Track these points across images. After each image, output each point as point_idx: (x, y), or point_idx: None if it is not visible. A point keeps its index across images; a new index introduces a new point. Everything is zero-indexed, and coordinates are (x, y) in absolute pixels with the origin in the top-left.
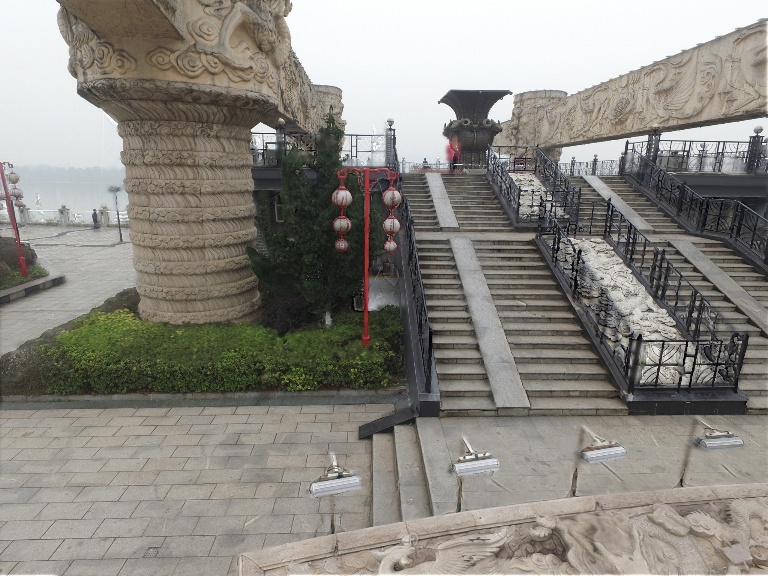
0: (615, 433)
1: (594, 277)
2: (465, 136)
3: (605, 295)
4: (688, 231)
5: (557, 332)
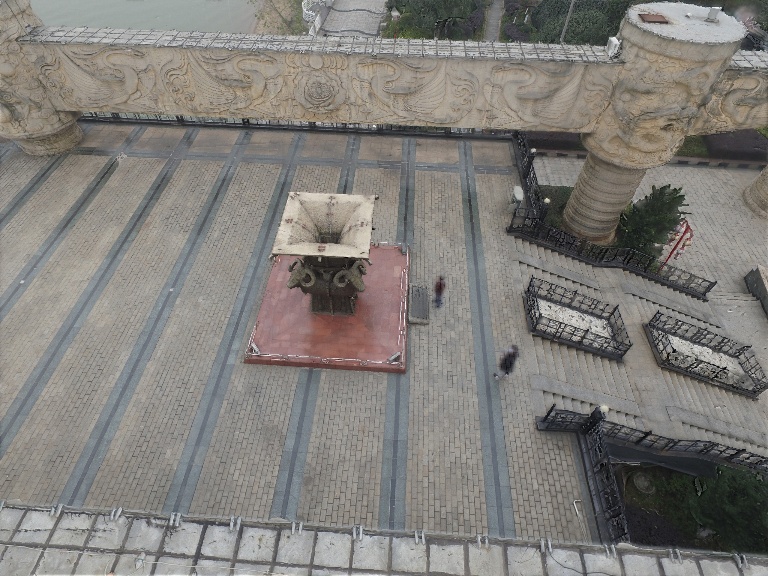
0: None
1: None
2: None
3: (705, 365)
4: (595, 265)
5: None
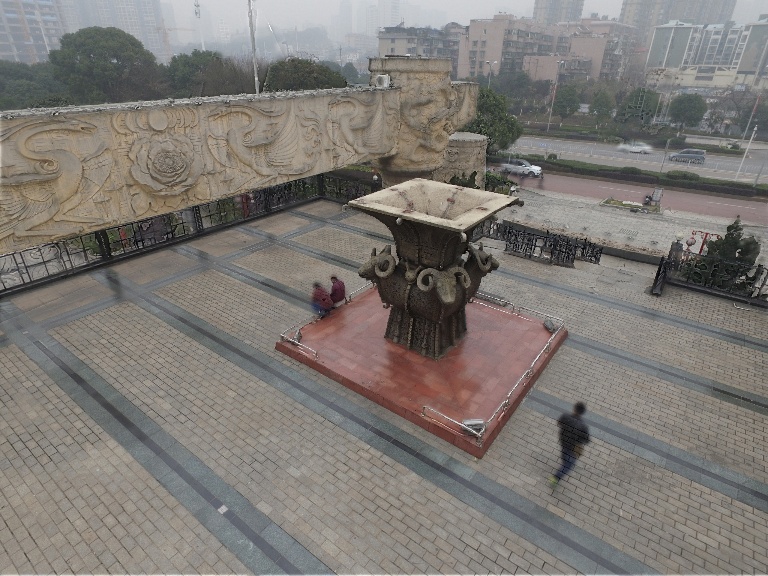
0: None
1: None
2: None
3: None
4: None
5: None
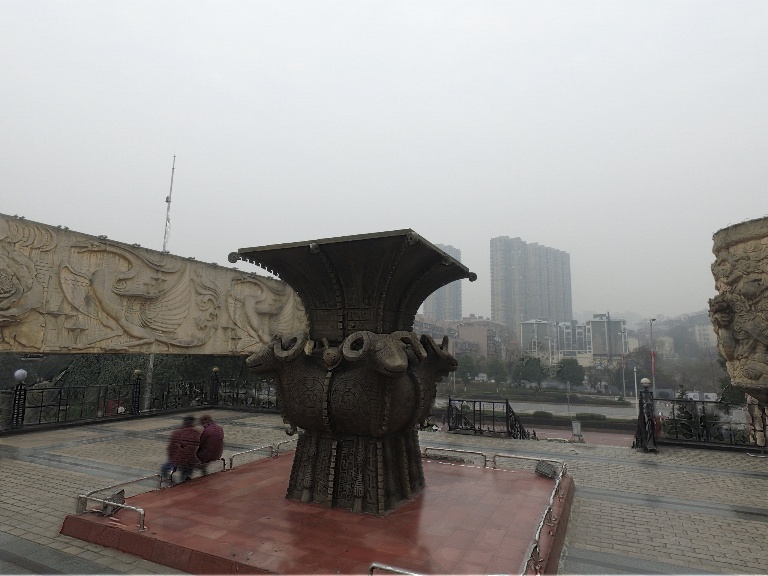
0: None
1: None
2: None
3: None
4: None
5: None
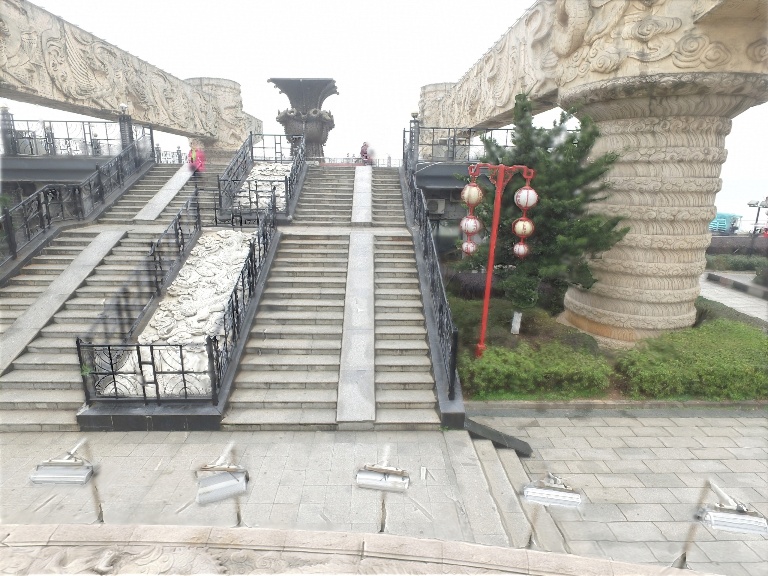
0: (15, 454)
1: (204, 273)
2: (293, 127)
3: None
4: (406, 224)
5: (106, 334)
